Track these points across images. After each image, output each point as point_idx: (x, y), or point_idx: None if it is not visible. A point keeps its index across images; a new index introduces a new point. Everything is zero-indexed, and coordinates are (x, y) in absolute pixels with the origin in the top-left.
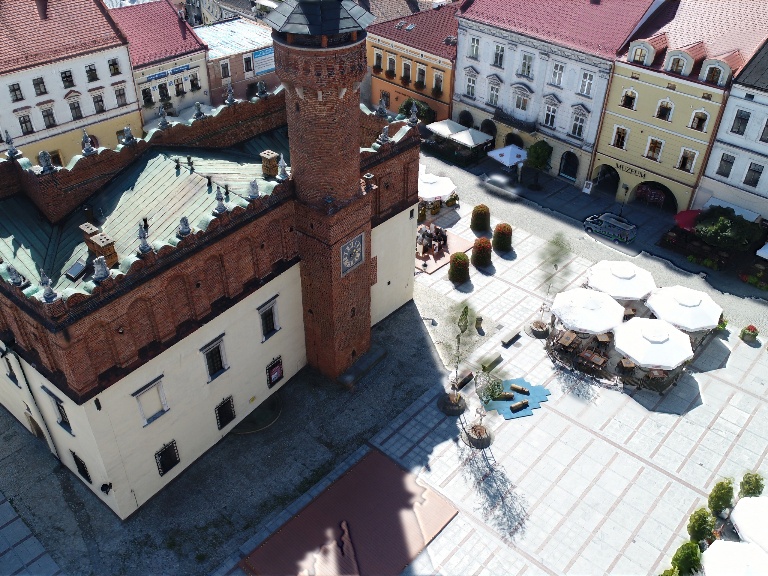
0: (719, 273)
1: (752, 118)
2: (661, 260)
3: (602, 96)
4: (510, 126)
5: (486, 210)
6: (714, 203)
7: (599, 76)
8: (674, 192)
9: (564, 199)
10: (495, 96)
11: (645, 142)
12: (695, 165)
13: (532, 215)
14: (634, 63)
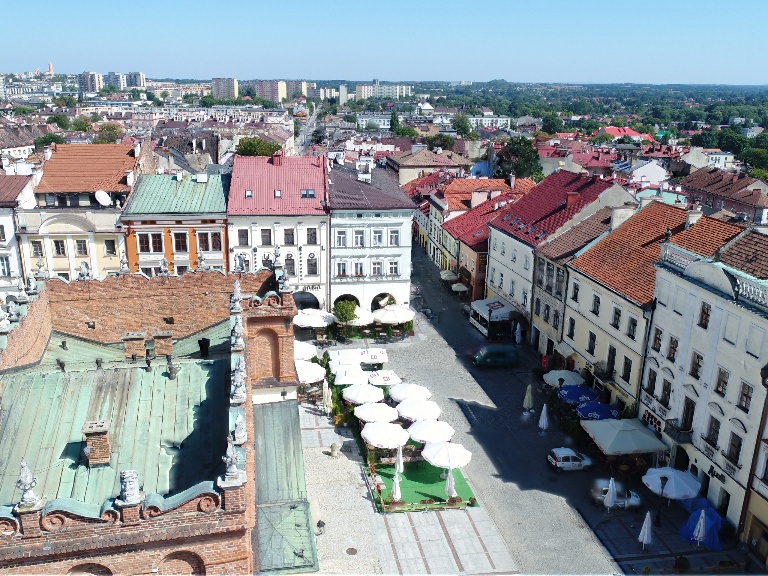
0: None
1: None
2: None
3: None
4: None
5: None
6: None
7: None
8: None
9: None
10: None
11: None
12: None
13: None
14: None
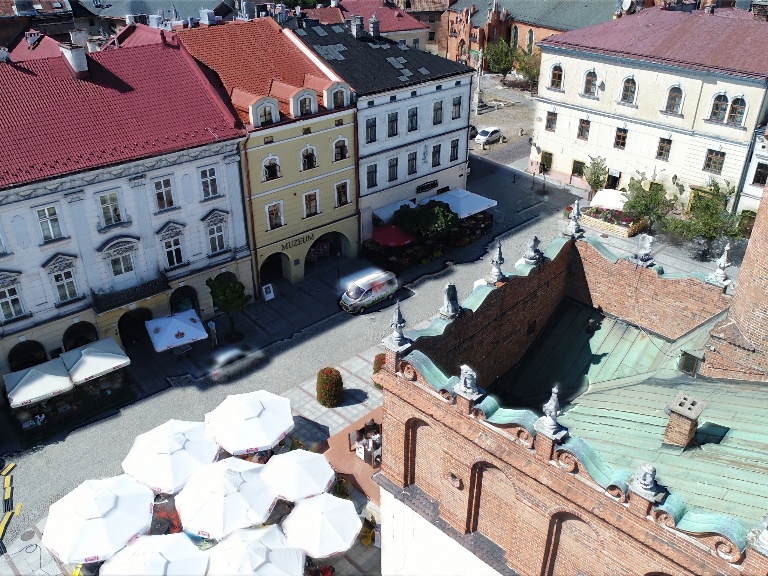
0: (448, 255)
1: (379, 121)
2: (423, 280)
3: (238, 185)
4: (137, 301)
5: (336, 370)
6: (382, 213)
7: (226, 164)
8: (343, 231)
9: (275, 319)
10: (68, 286)
11: (301, 203)
12: (350, 193)
13: (308, 349)
14: (267, 126)
